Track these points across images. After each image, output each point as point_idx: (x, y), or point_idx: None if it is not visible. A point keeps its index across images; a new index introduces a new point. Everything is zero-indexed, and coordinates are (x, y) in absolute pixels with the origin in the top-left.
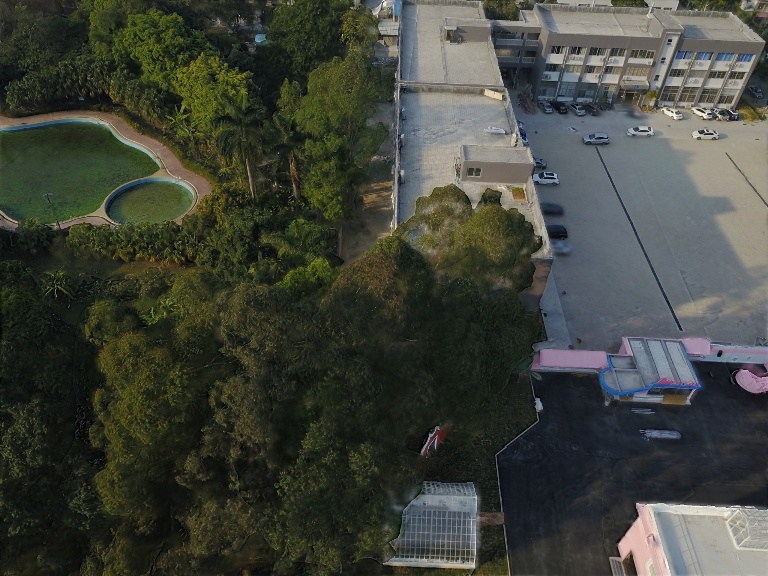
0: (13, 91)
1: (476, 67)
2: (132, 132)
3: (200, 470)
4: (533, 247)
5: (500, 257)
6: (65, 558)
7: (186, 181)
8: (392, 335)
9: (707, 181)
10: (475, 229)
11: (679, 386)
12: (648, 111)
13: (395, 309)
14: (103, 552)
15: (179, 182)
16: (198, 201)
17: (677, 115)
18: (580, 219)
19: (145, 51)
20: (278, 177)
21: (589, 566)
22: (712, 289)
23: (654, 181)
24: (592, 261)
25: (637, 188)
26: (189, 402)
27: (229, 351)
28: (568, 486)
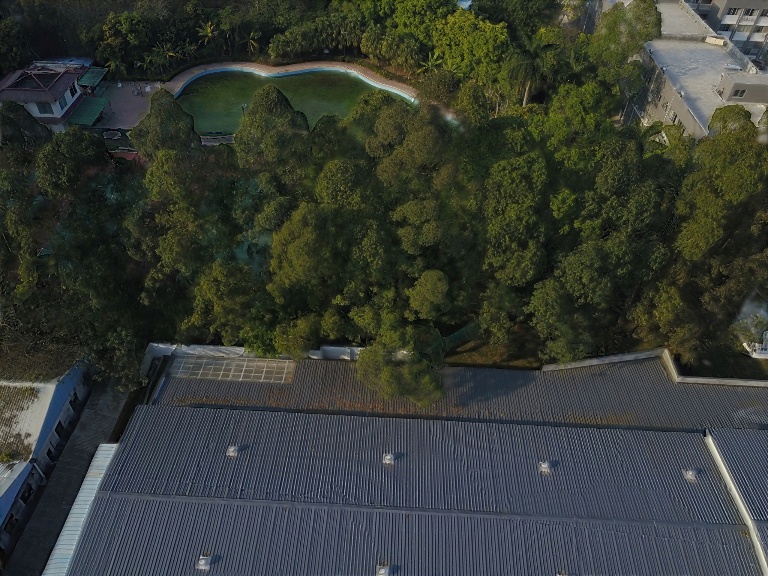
0: (278, 43)
1: (680, 22)
2: (380, 78)
3: None
4: None
5: None
6: (589, 318)
7: None
8: None
9: None
10: None
11: None
12: None
13: None
14: (657, 296)
15: None
16: None
17: None
18: None
19: (409, 6)
20: (538, 108)
21: None
22: None
23: None
24: None
25: None
26: (767, 176)
27: None
28: None
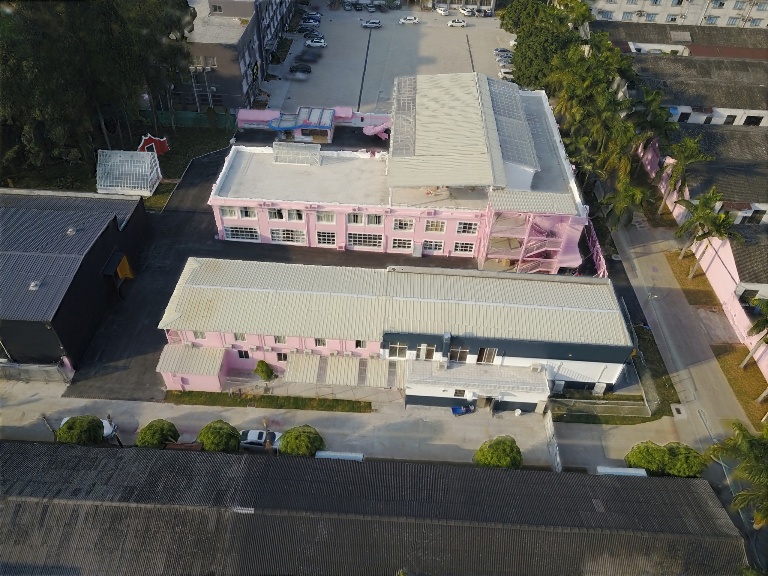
0: None
1: None
2: None
3: None
4: (191, 15)
5: None
6: None
7: None
8: (45, 6)
9: (438, 48)
10: None
11: (317, 126)
12: (425, 10)
13: None
14: None
15: None
16: None
17: (444, 12)
18: (328, 65)
19: None
20: None
21: None
22: None
23: (399, 48)
24: (321, 85)
25: (383, 51)
26: None
27: None
28: None
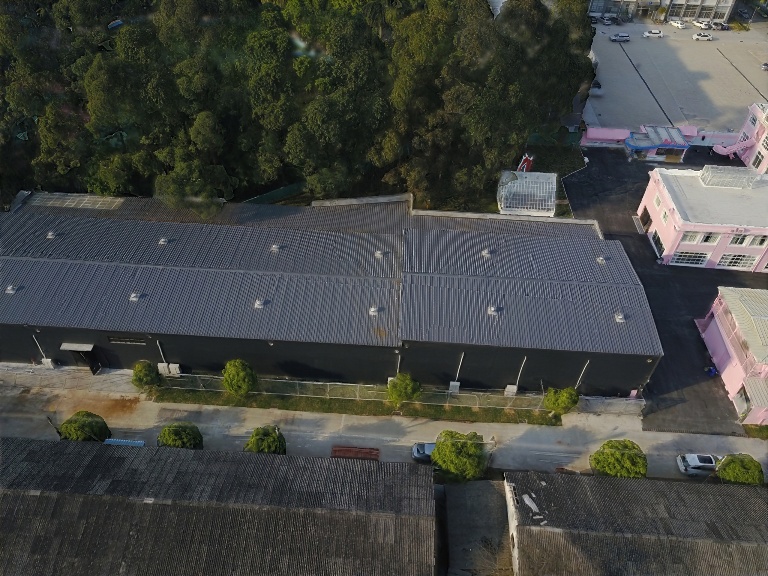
0: None
1: None
2: None
3: None
4: (590, 35)
5: (579, 11)
6: (347, 166)
7: None
8: (531, 29)
9: (702, 63)
10: (565, 0)
11: (676, 146)
12: (659, 23)
13: (533, 15)
14: (383, 140)
15: None
16: None
17: (681, 25)
18: (609, 80)
19: None
20: None
21: (620, 219)
22: (701, 116)
23: (663, 62)
24: (618, 101)
25: (650, 66)
26: (444, 42)
27: (461, 21)
28: (606, 191)
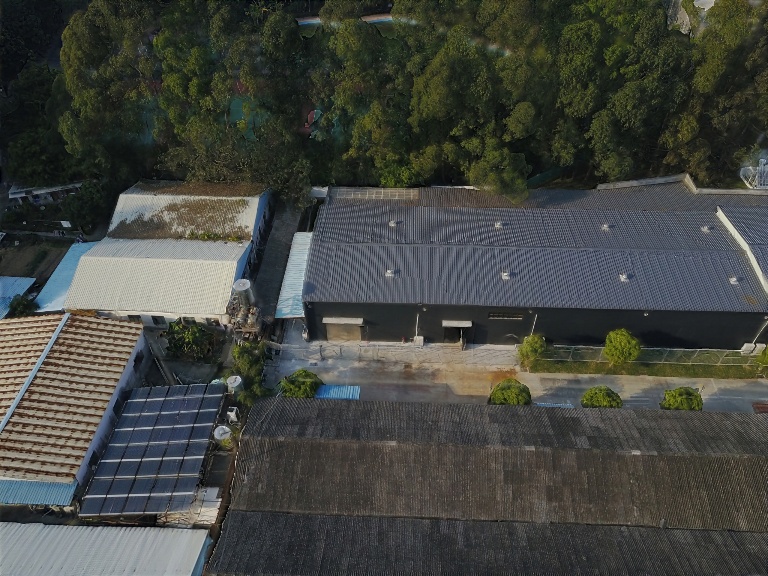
0: None
1: None
2: None
3: None
4: None
5: None
6: None
7: None
8: None
9: None
10: None
11: None
12: None
13: None
14: (680, 123)
15: None
16: None
17: None
18: None
19: None
20: None
21: None
22: None
23: None
24: None
25: None
26: (755, 26)
27: None
28: None
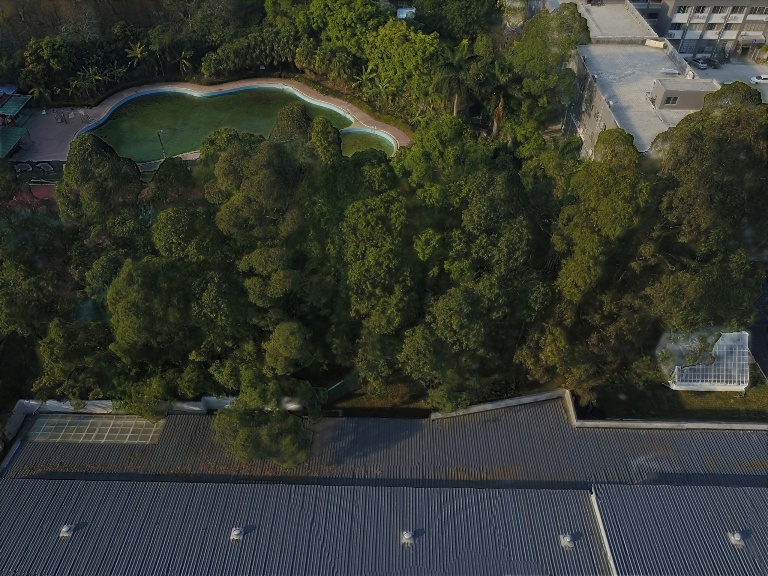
0: (210, 61)
1: (623, 24)
2: (316, 94)
3: (652, 256)
4: None
5: None
6: None
7: (381, 130)
8: (758, 170)
9: None
10: None
11: None
12: (763, 63)
13: (762, 150)
14: (542, 338)
15: (375, 131)
16: (399, 145)
17: None
18: None
19: (339, 19)
20: (471, 121)
21: None
22: None
23: None
24: None
25: None
26: (645, 208)
27: (668, 173)
28: None
